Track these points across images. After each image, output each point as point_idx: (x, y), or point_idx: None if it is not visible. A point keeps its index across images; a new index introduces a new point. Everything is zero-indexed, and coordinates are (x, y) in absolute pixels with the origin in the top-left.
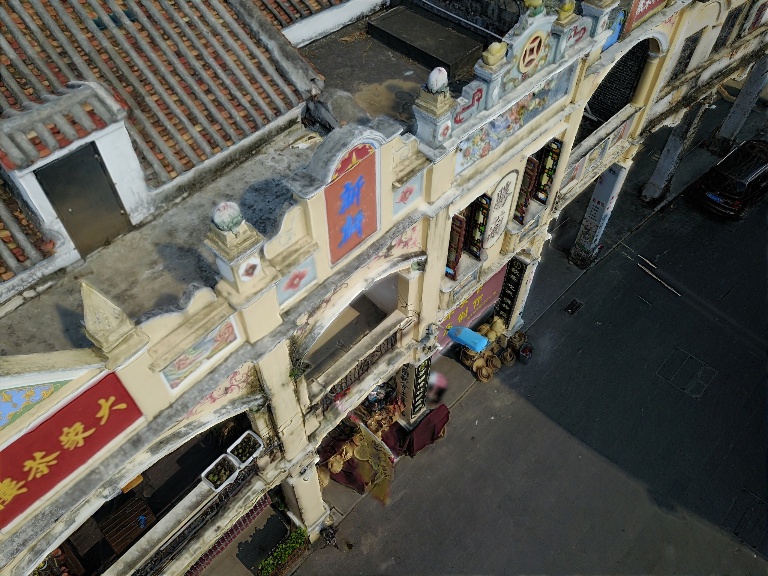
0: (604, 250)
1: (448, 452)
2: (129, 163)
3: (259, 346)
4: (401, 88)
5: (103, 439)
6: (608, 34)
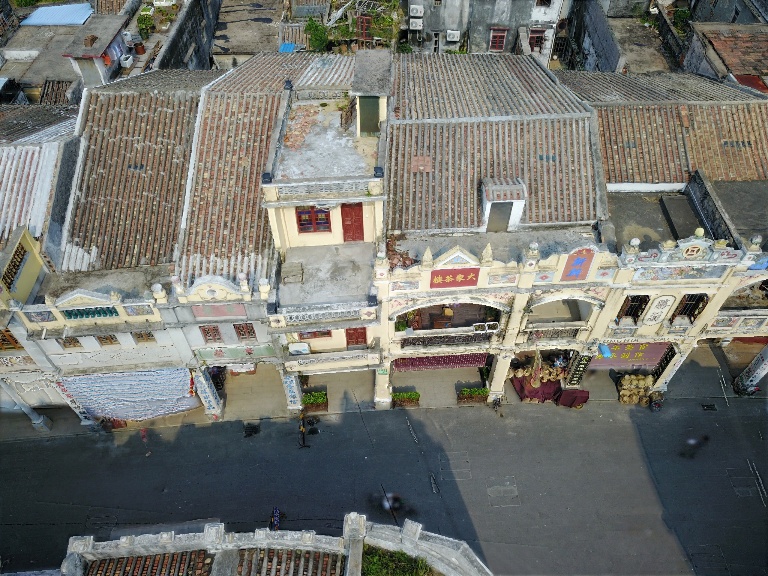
0: (763, 395)
1: (576, 417)
2: (519, 212)
3: (519, 290)
4: (650, 234)
5: (464, 284)
6: (752, 263)
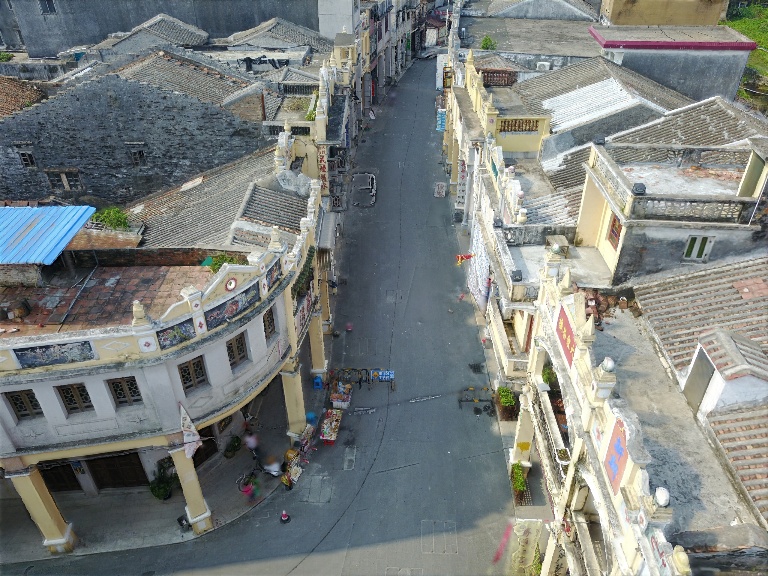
0: None
1: None
2: None
3: (578, 418)
4: None
5: None
6: None
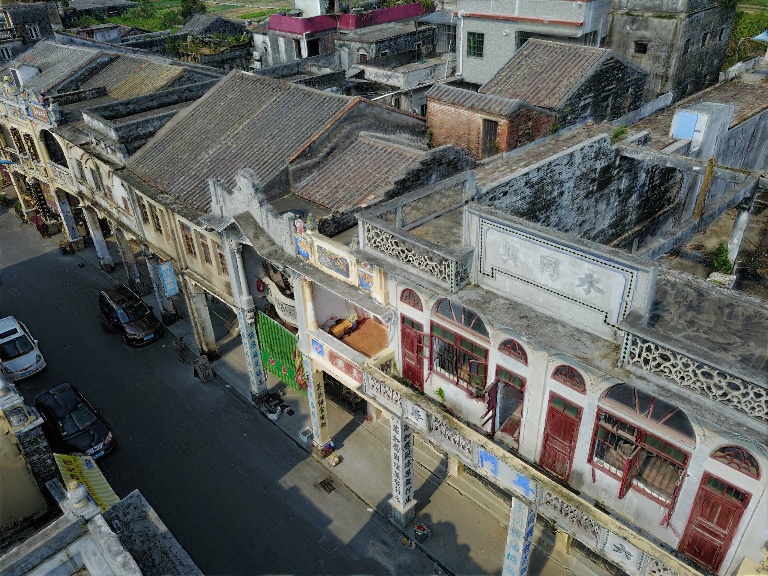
0: None
1: None
2: None
3: None
4: None
5: None
6: None
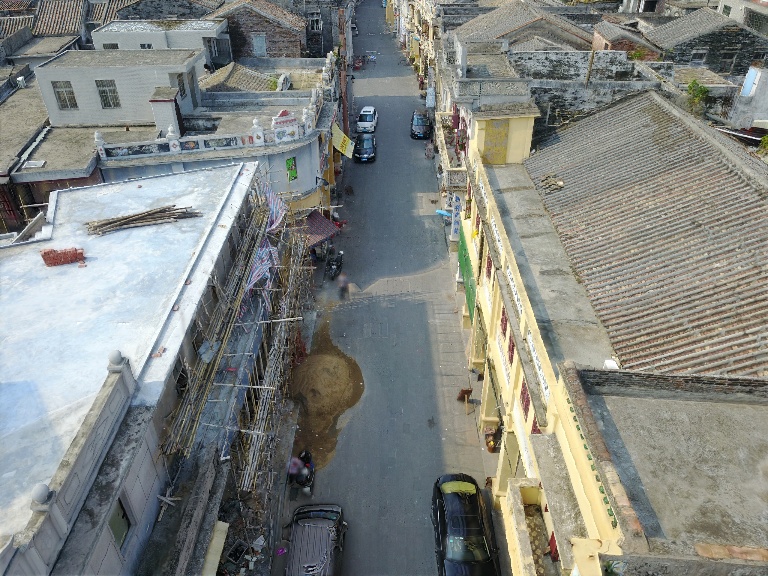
0: None
1: None
2: None
3: None
4: None
5: None
6: None
